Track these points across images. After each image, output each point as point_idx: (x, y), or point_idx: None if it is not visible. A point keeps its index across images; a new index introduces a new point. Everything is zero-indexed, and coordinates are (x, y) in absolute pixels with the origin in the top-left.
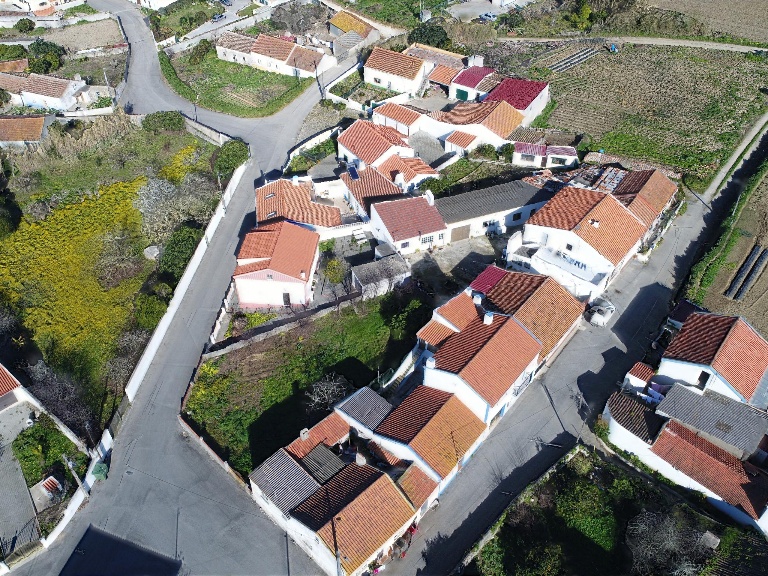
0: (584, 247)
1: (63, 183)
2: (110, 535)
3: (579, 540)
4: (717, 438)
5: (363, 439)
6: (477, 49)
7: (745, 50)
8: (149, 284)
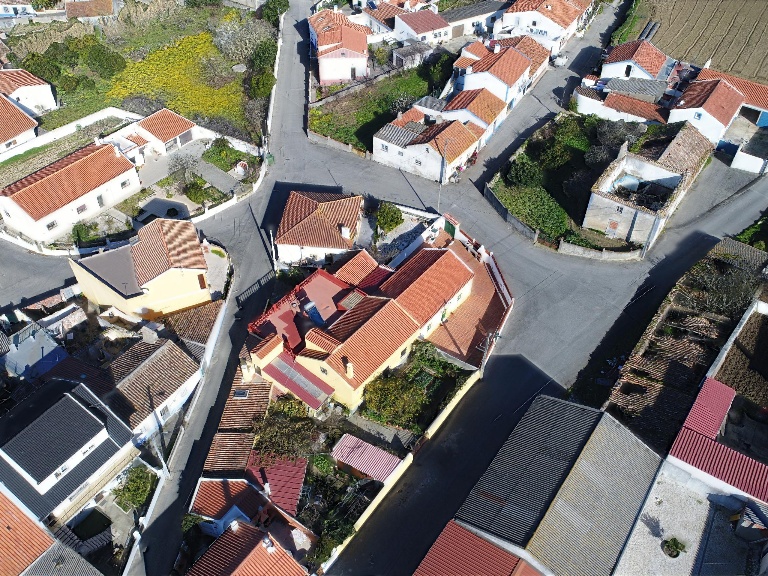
0: (544, 20)
1: (144, 41)
2: (291, 183)
3: (571, 149)
4: (640, 94)
5: (433, 121)
6: None
7: None
8: (253, 75)
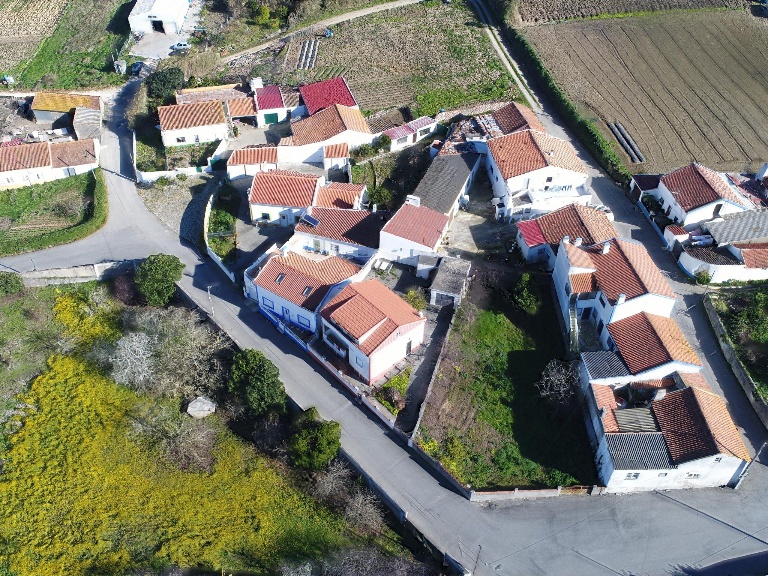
0: (564, 173)
1: None
2: None
3: None
4: (764, 237)
5: (620, 389)
6: (215, 77)
7: (416, 1)
8: (275, 426)
